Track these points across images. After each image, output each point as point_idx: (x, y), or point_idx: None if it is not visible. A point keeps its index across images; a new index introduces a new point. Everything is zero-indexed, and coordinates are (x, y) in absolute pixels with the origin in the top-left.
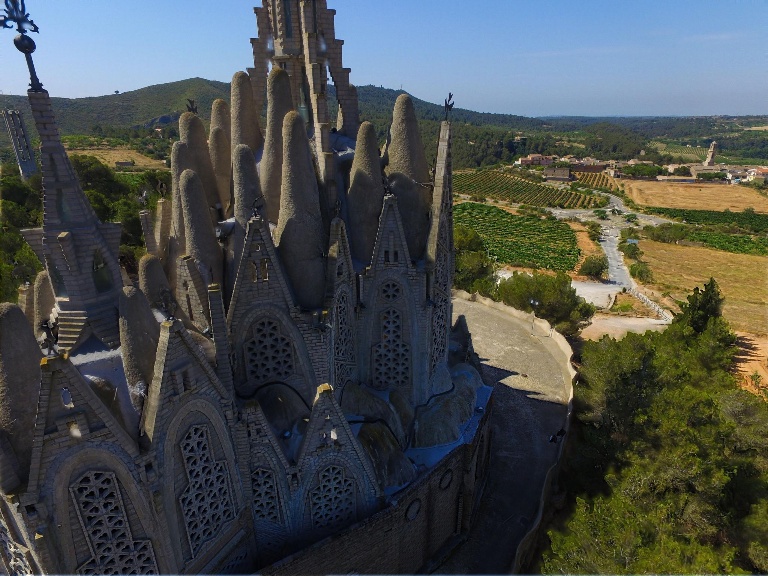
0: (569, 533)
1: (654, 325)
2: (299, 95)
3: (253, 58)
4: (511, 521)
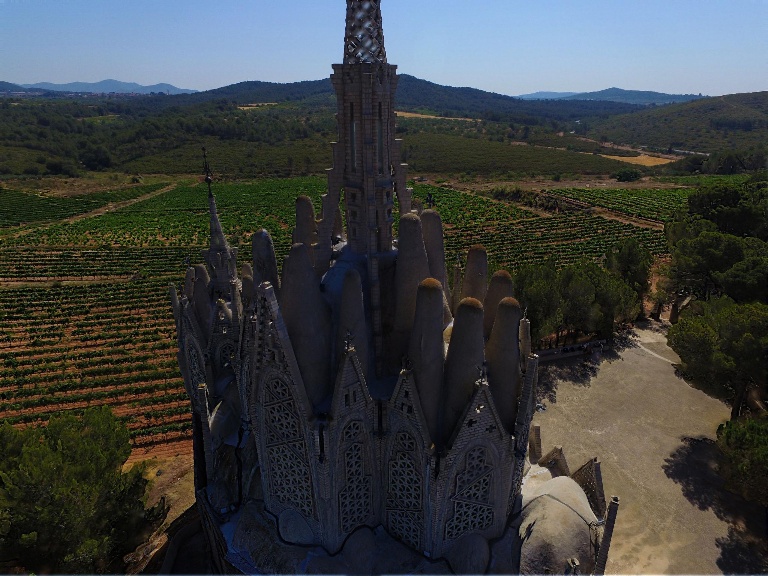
0: None
1: None
2: (348, 215)
3: None
4: None
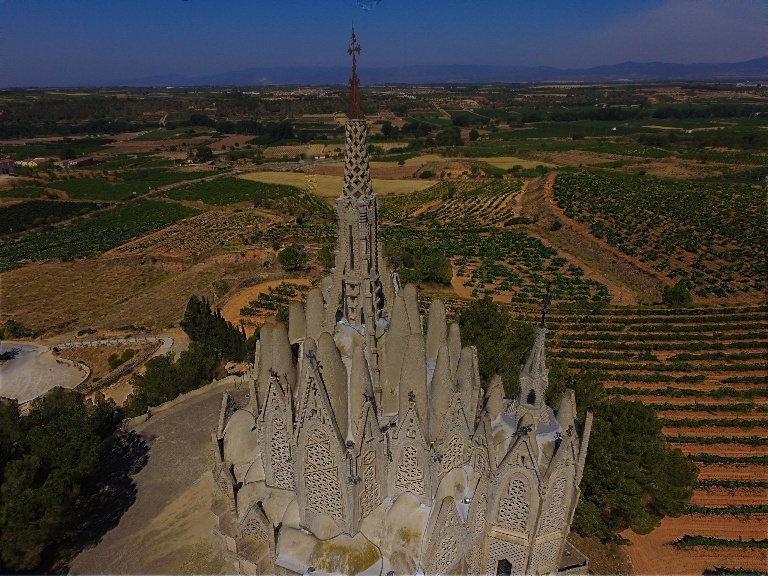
0: None
1: (172, 348)
2: None
3: (368, 287)
4: None
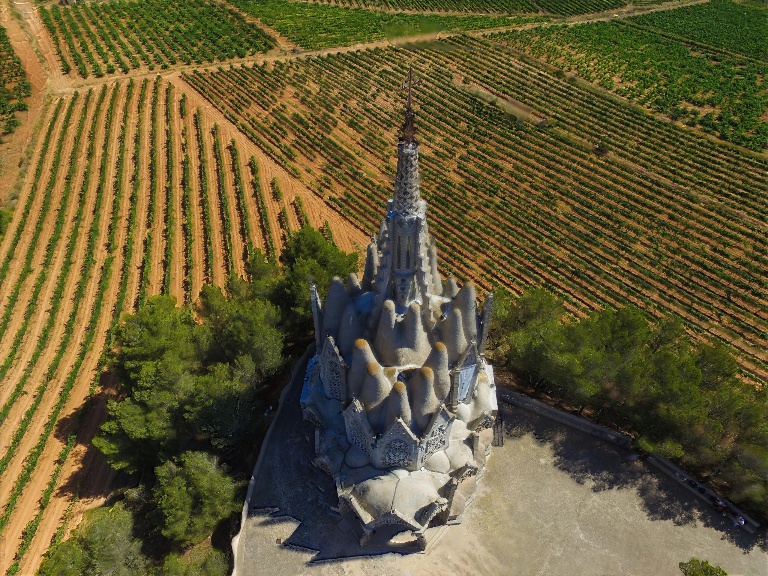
0: (267, 422)
1: None
2: None
3: None
4: (295, 398)
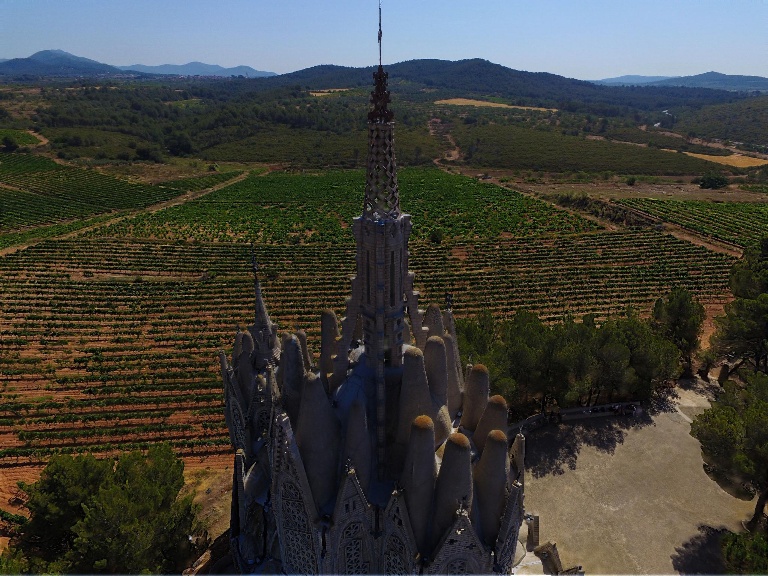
0: None
1: None
2: None
3: None
4: None
